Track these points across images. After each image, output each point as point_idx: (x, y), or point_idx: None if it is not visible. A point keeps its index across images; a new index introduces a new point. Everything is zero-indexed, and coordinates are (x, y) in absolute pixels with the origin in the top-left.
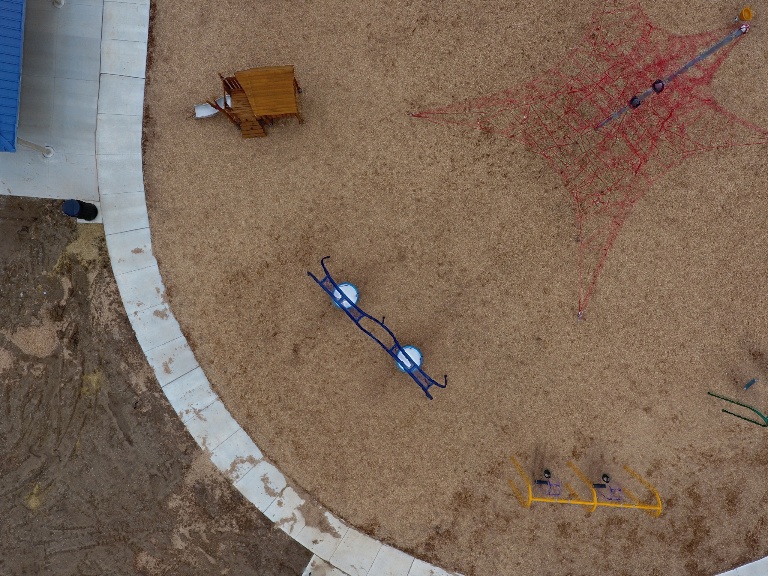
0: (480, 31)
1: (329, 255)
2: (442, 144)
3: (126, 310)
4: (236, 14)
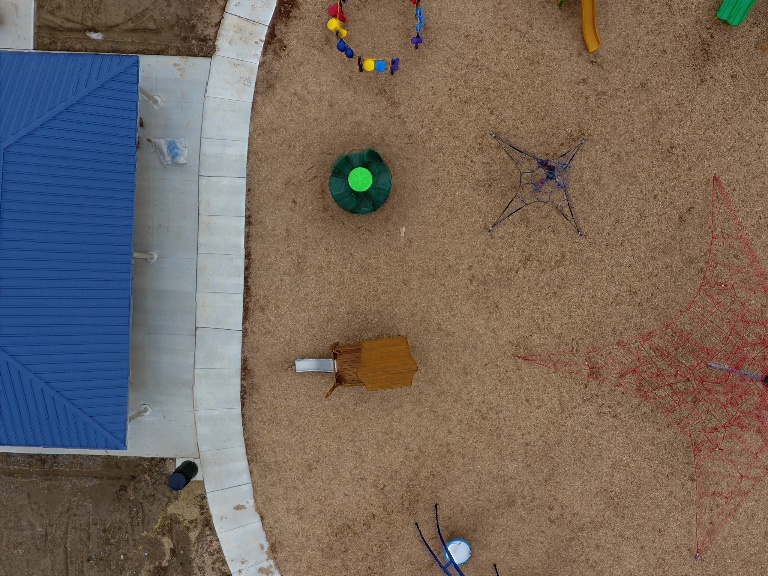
0: (586, 270)
1: (436, 502)
2: (550, 386)
3: (230, 568)
4: (333, 261)
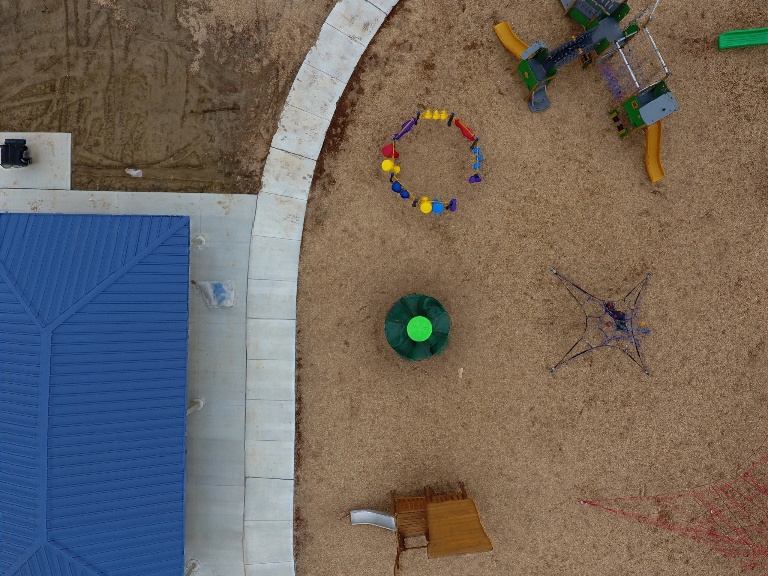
0: (653, 410)
1: None
2: (617, 532)
3: None
4: (388, 404)
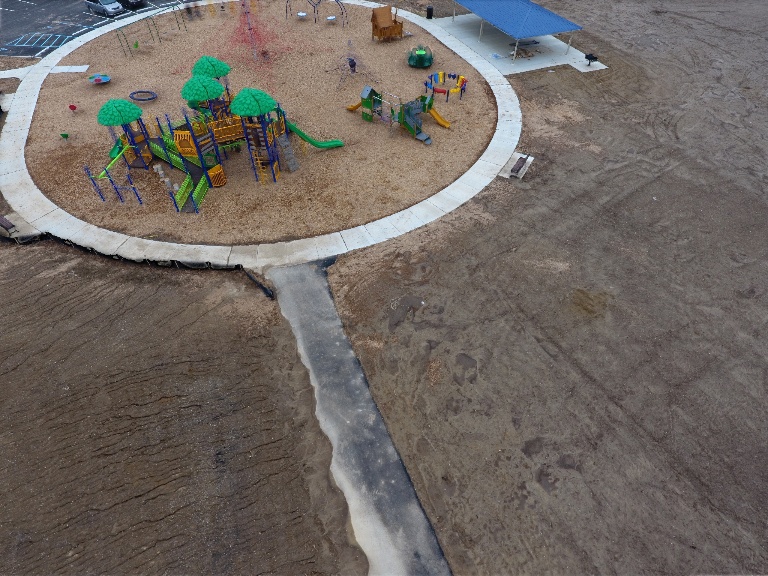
0: None
1: None
2: None
3: None
4: None
